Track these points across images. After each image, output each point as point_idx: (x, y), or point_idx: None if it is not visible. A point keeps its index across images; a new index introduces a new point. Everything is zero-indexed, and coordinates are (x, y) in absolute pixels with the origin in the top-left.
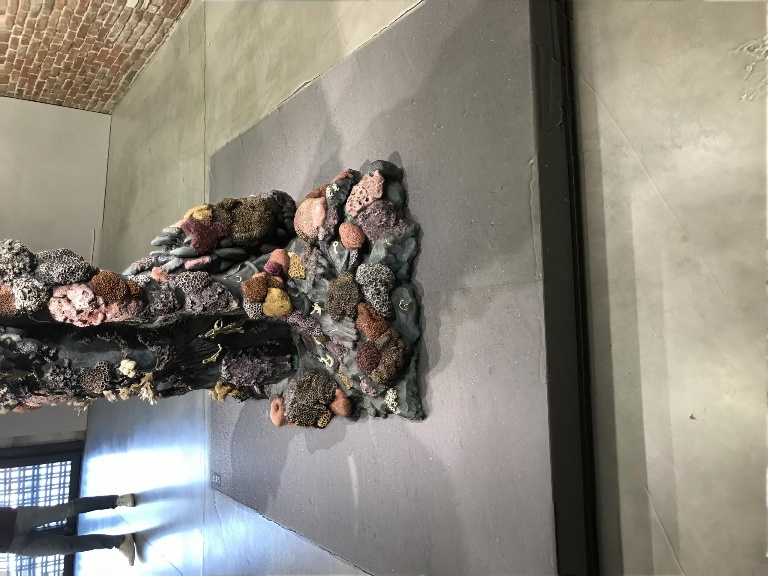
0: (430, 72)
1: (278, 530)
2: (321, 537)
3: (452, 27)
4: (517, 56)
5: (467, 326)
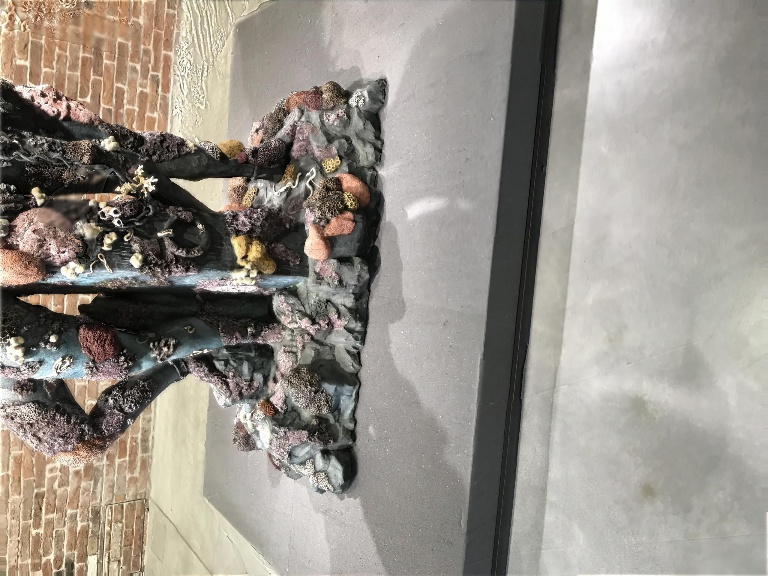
0: (249, 101)
1: (542, 575)
2: (477, 295)
3: (242, 80)
4: (263, 17)
5: (345, 36)
